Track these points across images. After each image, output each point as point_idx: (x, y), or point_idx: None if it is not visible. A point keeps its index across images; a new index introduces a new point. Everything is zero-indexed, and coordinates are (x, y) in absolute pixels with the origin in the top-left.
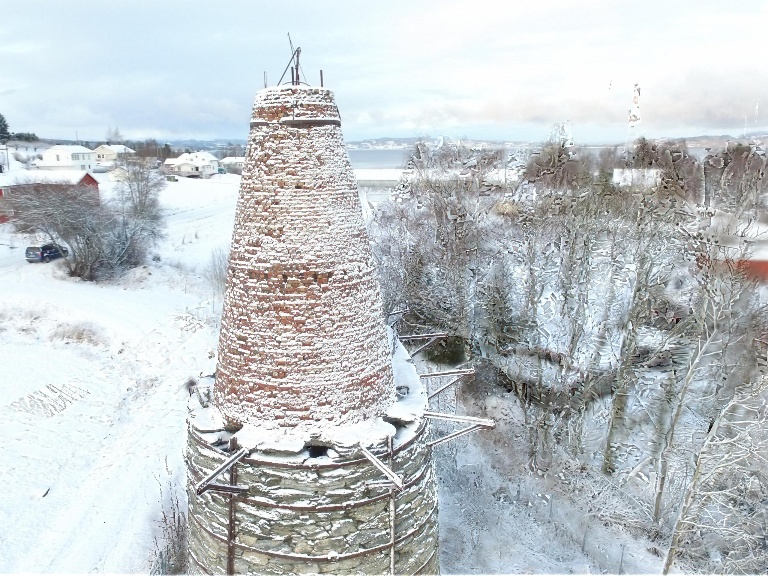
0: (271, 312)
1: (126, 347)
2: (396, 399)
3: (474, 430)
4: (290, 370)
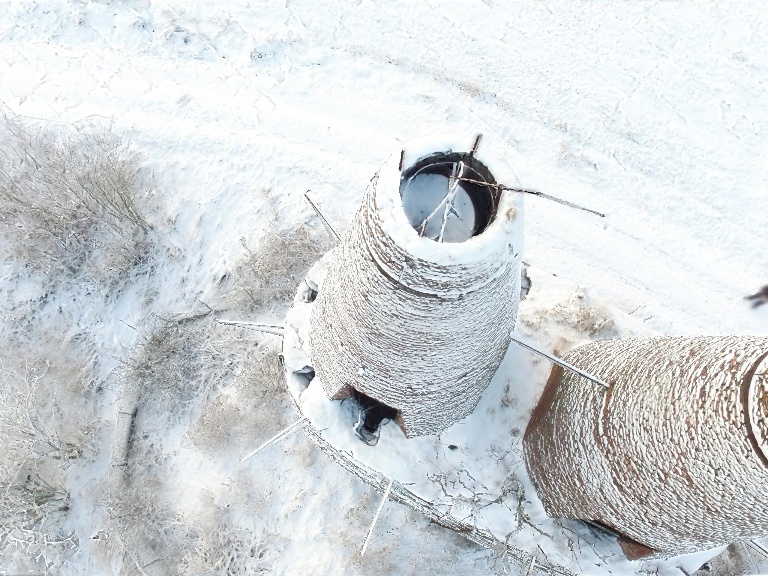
0: None
1: None
2: None
3: None
4: None
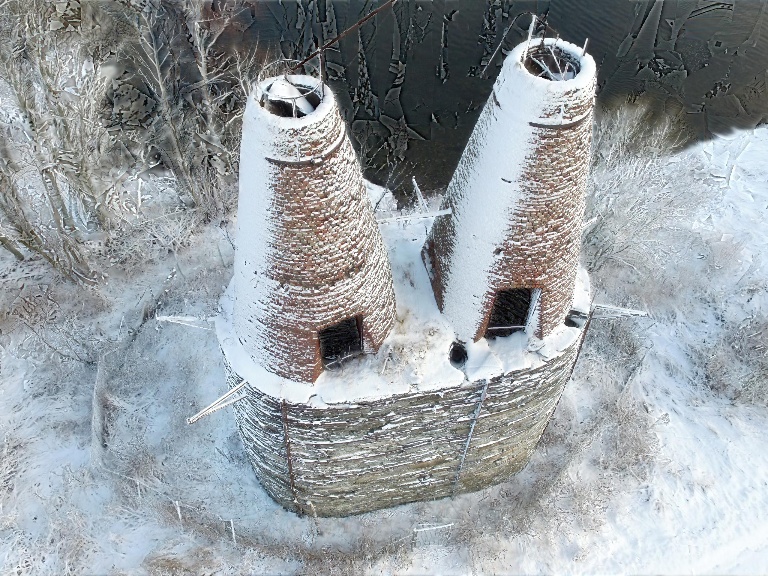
0: None
1: None
2: None
3: None
4: None
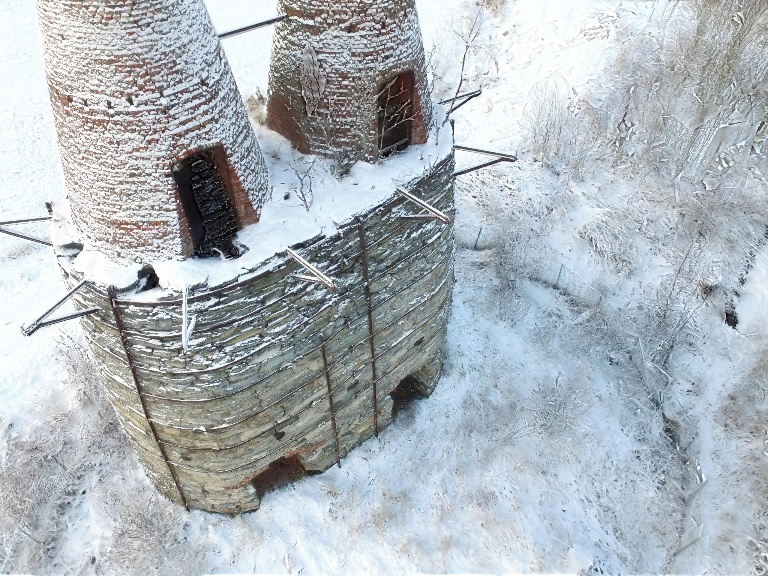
0: None
1: (512, 31)
2: (178, 257)
3: None
4: None
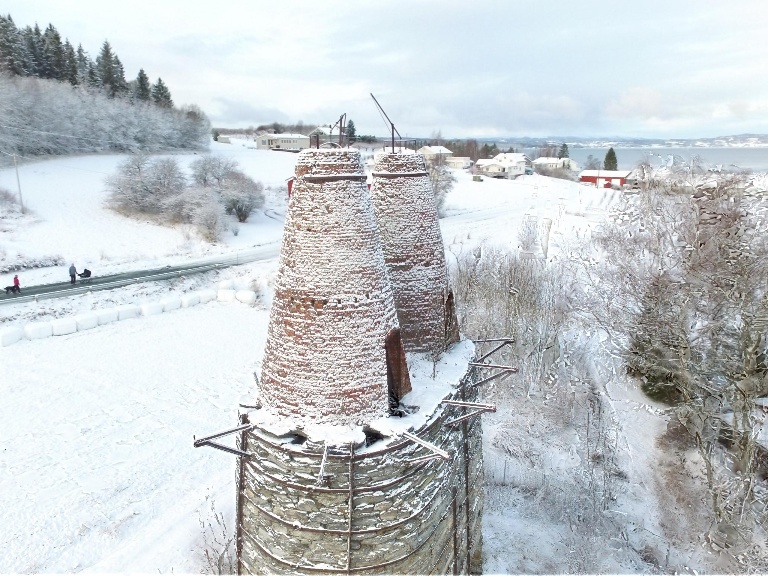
0: (282, 325)
1: None
2: (386, 415)
3: (435, 458)
4: (289, 372)
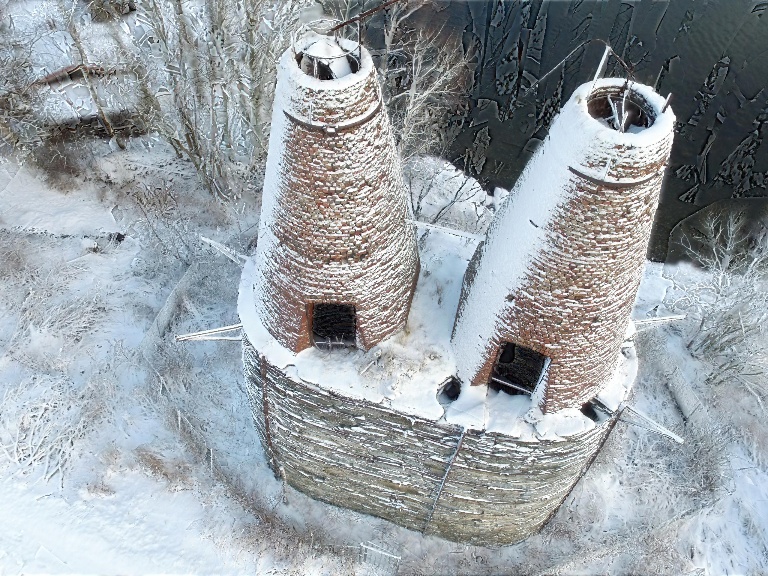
0: None
1: None
2: None
3: None
4: None
